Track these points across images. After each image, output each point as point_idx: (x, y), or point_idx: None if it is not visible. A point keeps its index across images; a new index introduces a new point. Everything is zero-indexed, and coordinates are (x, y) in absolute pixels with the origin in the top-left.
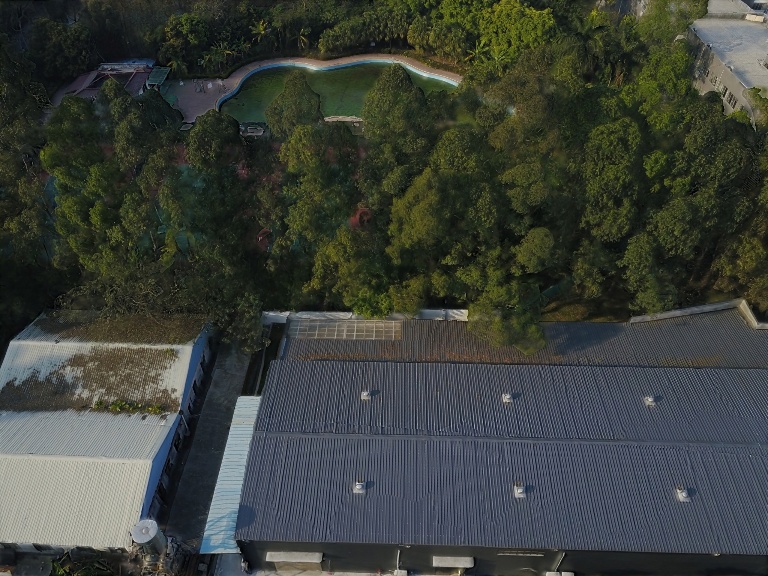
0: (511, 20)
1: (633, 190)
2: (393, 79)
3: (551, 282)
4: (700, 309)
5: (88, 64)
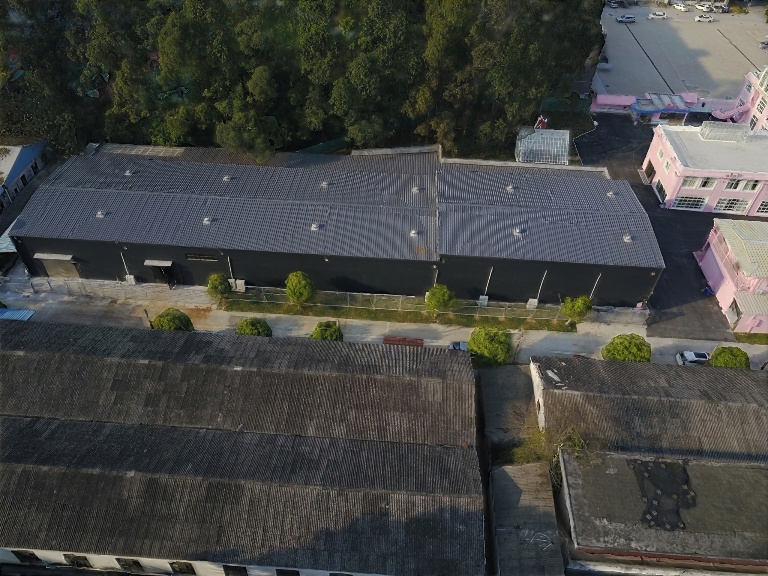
0: None
1: (333, 45)
2: None
3: (321, 140)
4: (407, 150)
5: None
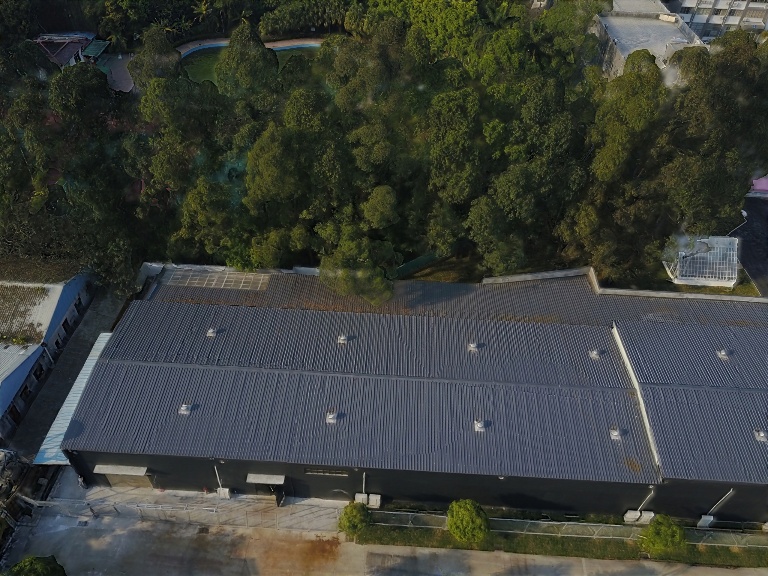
0: (437, 10)
1: (474, 155)
2: (241, 38)
3: None
4: (550, 274)
5: (28, 34)
